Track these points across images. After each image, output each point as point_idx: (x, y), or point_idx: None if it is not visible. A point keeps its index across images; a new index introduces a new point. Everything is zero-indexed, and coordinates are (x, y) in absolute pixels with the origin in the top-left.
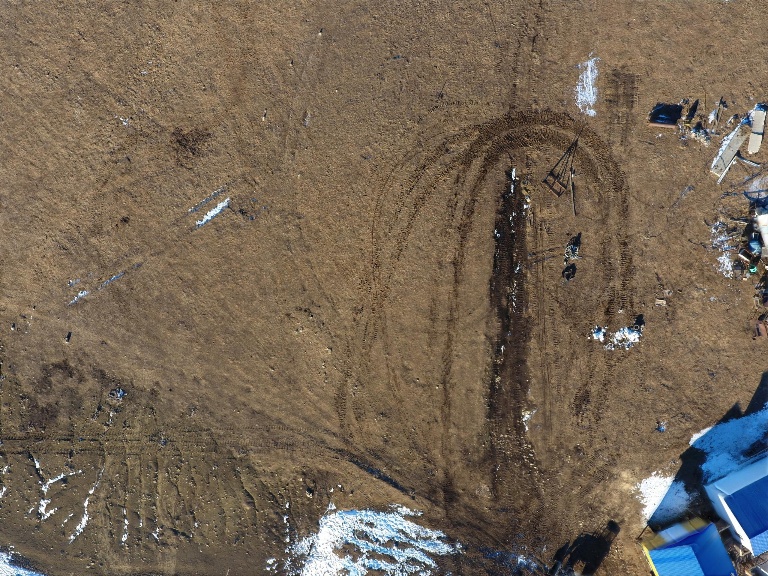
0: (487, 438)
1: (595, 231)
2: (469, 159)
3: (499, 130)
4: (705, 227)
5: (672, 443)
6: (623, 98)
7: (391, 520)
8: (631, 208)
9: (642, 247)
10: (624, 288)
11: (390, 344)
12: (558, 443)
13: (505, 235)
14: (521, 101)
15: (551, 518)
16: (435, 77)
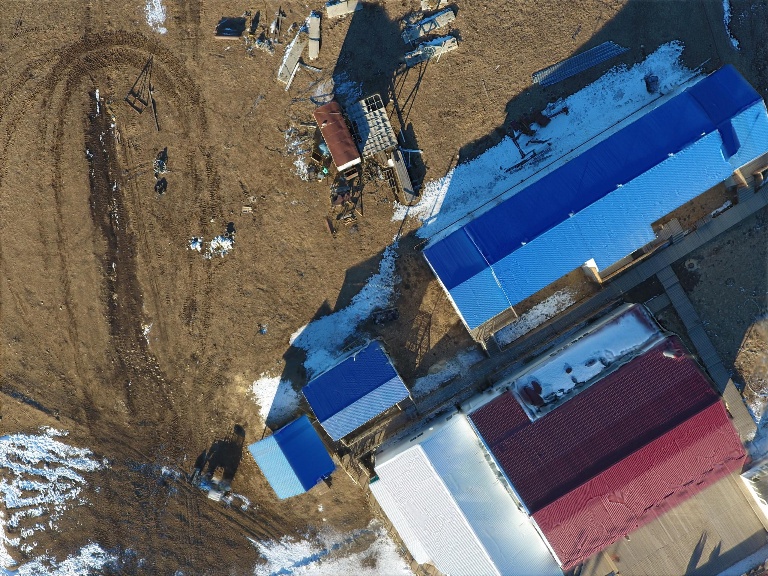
0: (114, 354)
1: (179, 145)
2: (53, 83)
3: (78, 53)
4: (279, 133)
5: (274, 344)
6: (190, 14)
7: (41, 442)
8: (210, 120)
9: (224, 157)
10: (213, 198)
11: (9, 269)
12: (176, 353)
13: (98, 155)
14: (96, 23)
15: (186, 427)
16: (13, 5)
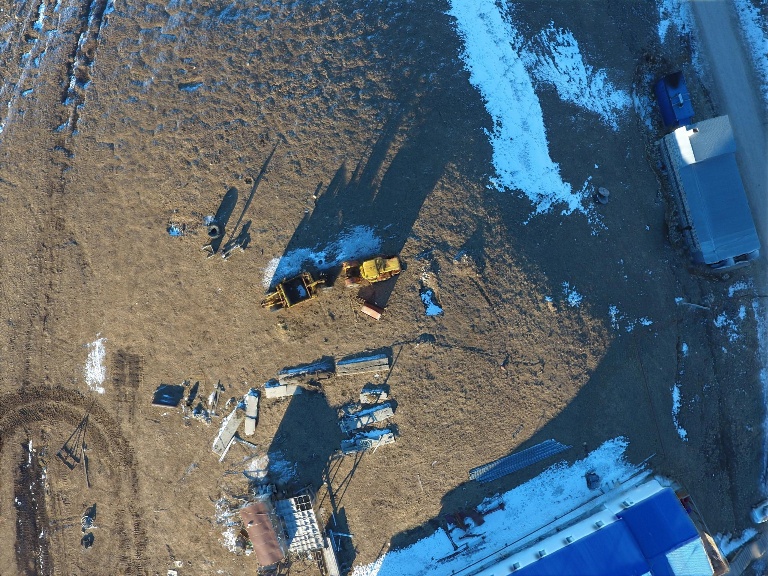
0: None
1: (109, 503)
2: None
3: (14, 404)
4: (210, 503)
5: None
6: (129, 377)
7: None
8: (141, 482)
9: (153, 519)
10: (139, 557)
11: None
12: None
13: (26, 503)
14: (34, 377)
15: None
16: None
